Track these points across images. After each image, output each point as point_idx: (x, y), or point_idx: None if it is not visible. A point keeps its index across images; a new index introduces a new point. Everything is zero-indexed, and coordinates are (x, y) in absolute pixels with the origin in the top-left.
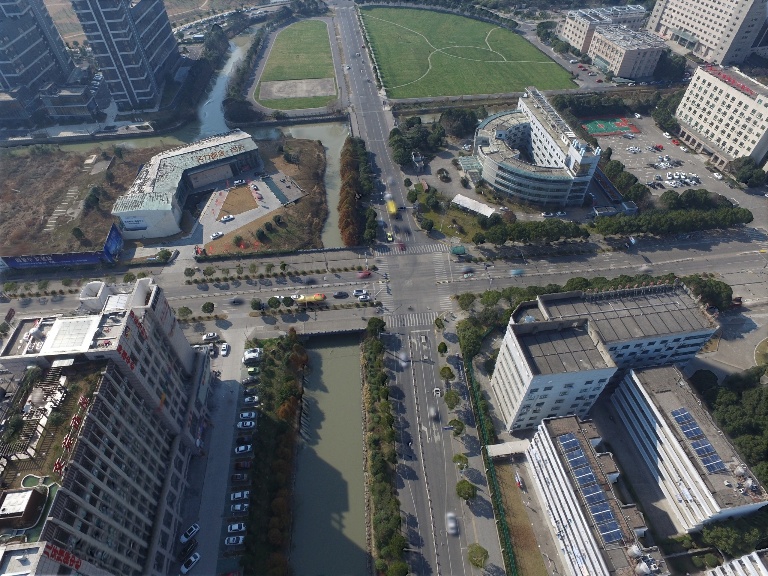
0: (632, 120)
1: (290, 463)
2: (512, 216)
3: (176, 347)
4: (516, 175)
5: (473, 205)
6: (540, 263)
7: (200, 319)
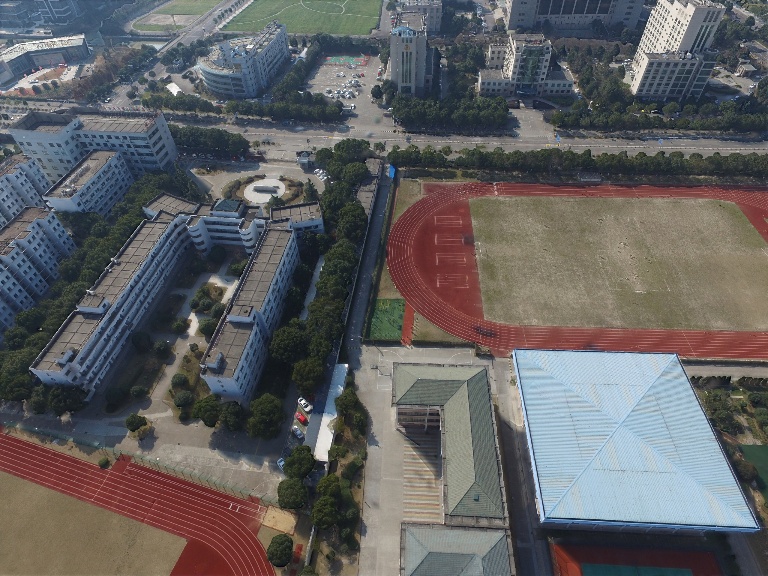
0: (373, 58)
1: None
2: (179, 94)
3: None
4: (205, 71)
5: (174, 89)
6: (176, 124)
7: None
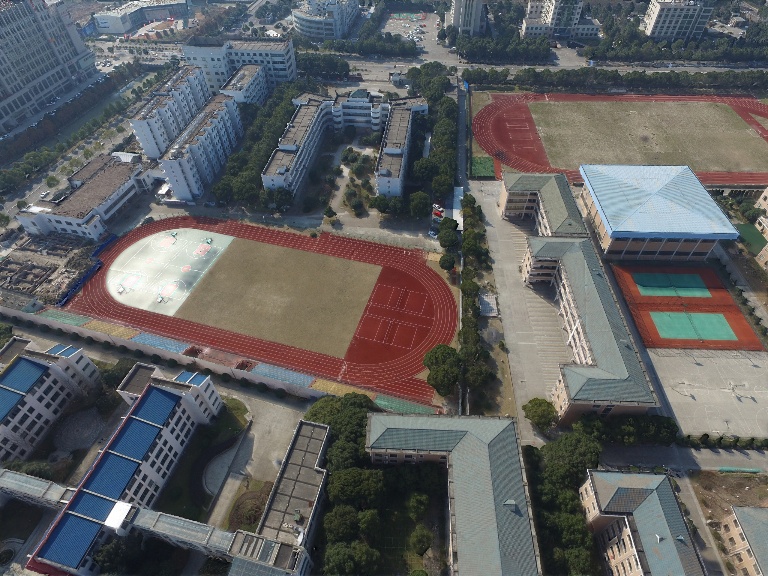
0: (429, 14)
1: (107, 94)
2: None
3: (70, 34)
4: (300, 19)
5: None
6: None
7: (108, 57)
